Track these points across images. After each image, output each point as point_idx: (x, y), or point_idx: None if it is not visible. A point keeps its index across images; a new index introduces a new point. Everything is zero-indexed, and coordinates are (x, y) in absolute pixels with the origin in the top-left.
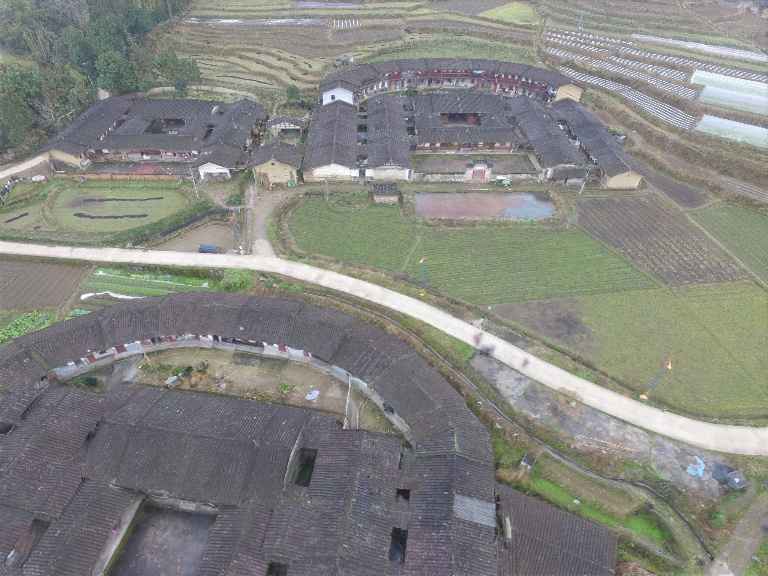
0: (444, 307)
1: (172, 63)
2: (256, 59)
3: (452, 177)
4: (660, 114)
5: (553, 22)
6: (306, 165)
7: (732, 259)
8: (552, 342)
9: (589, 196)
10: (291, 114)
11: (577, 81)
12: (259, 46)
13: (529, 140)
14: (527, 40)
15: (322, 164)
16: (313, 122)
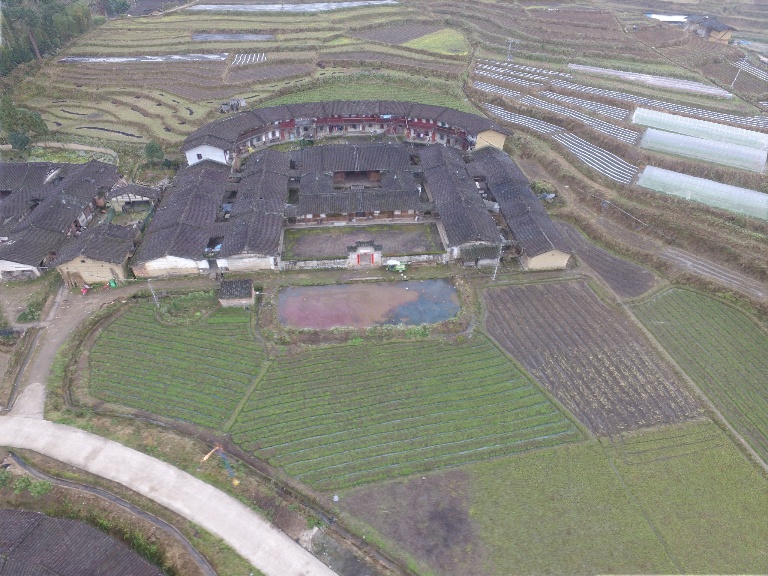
0: (263, 506)
1: (9, 117)
2: (131, 105)
3: (332, 263)
4: (596, 164)
5: (483, 51)
6: (137, 256)
7: (683, 380)
8: (417, 568)
9: (505, 283)
10: (152, 177)
11: (504, 122)
12: (139, 88)
13: (435, 206)
14: (452, 73)
15: (154, 257)
16: (170, 190)
